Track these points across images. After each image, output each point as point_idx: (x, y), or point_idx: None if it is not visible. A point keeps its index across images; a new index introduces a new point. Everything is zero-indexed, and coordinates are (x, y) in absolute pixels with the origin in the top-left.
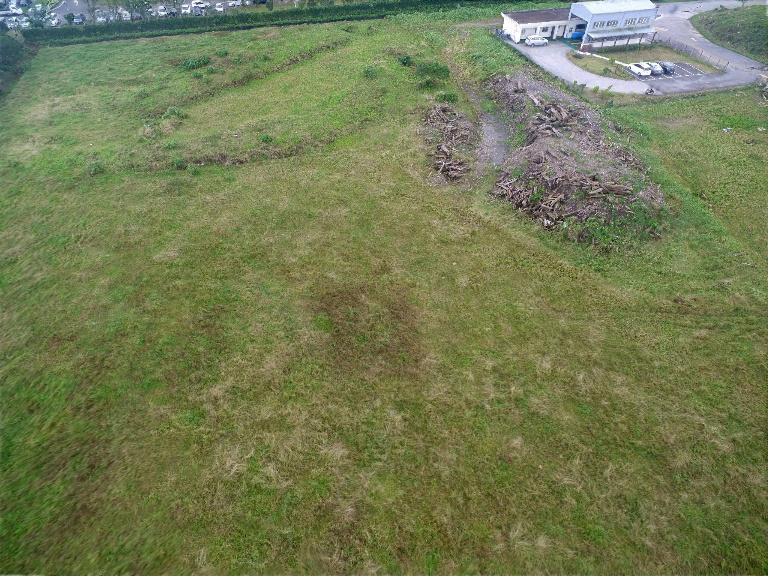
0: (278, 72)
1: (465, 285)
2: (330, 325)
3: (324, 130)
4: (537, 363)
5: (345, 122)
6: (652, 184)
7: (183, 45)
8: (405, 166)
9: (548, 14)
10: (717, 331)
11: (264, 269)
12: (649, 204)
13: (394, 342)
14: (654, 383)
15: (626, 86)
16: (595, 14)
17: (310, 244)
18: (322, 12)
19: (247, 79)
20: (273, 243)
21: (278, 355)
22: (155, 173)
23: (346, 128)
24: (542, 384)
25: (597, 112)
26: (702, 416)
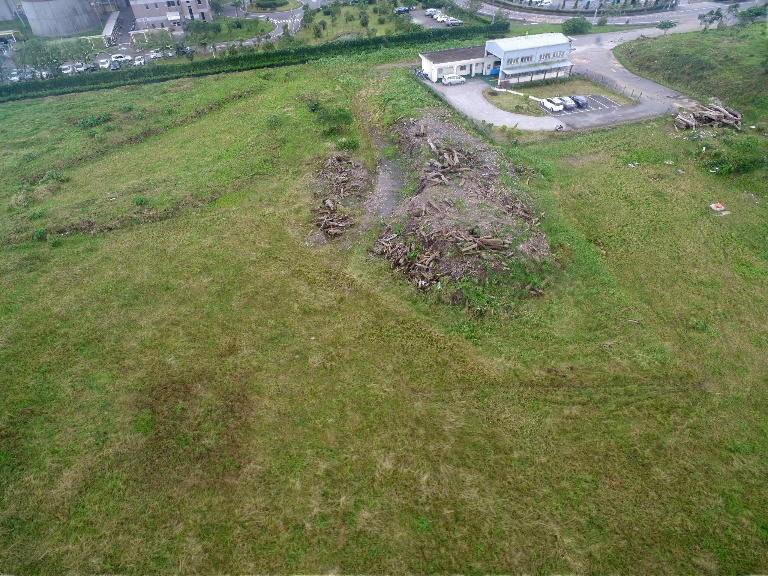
0: (181, 126)
1: (318, 365)
2: (152, 426)
3: (208, 188)
4: (378, 462)
5: (233, 178)
6: (537, 234)
7: (89, 102)
8: (286, 224)
9: (466, 52)
10: (591, 407)
11: (97, 357)
12: (530, 258)
13: (219, 444)
14: (508, 481)
15: (537, 123)
16: (507, 51)
17: (158, 323)
18: (242, 60)
19: (145, 135)
20: (116, 324)
21: (78, 471)
22: (12, 247)
23: (232, 184)
24: (378, 491)
25: (498, 154)
26: (557, 523)
